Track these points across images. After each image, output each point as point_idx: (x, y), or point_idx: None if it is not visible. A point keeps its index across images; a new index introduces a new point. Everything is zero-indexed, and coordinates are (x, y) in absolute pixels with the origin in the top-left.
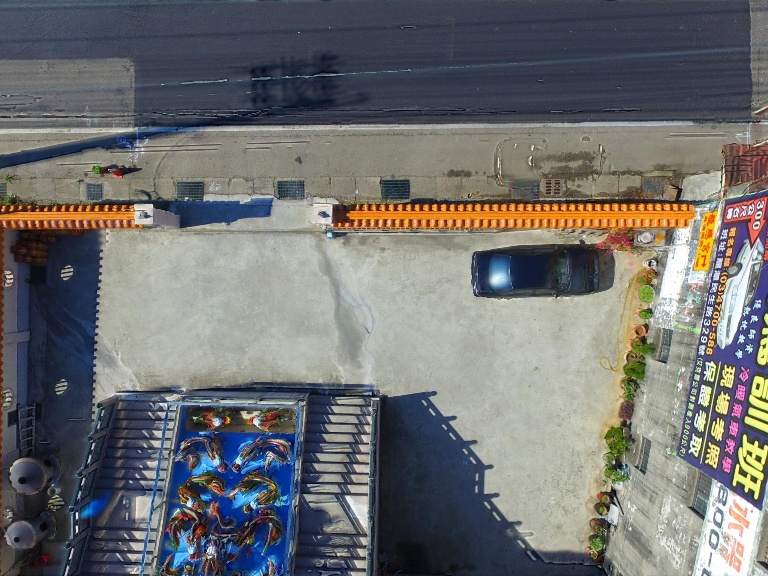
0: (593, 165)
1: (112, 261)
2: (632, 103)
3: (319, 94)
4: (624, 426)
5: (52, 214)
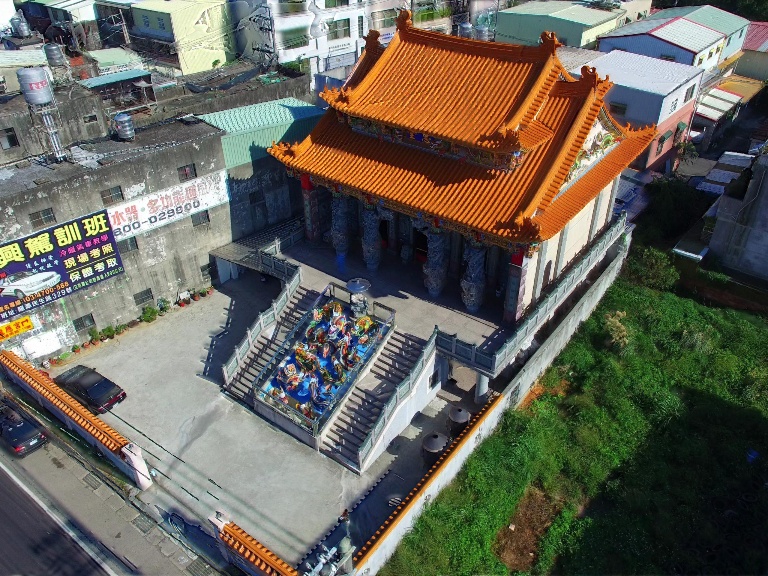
0: (3, 422)
1: (293, 557)
2: None
3: (57, 567)
4: (142, 320)
5: (278, 568)
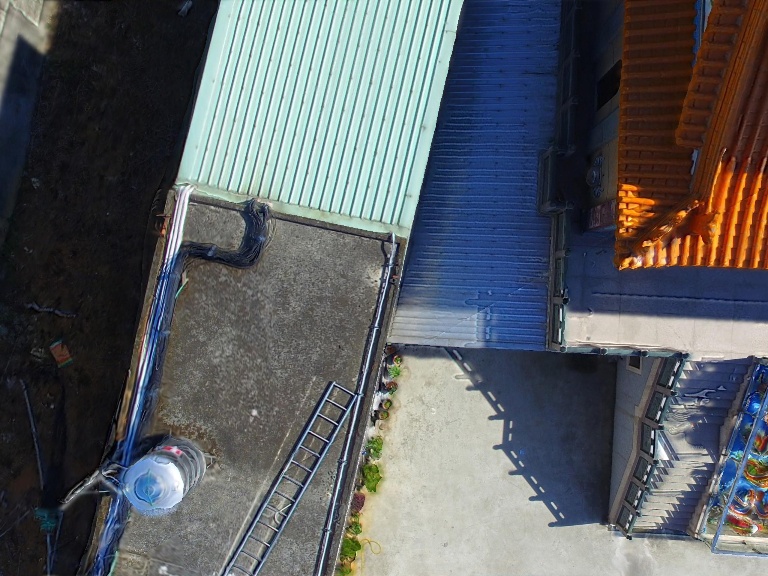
0: None
1: None
2: None
3: None
4: None
5: None
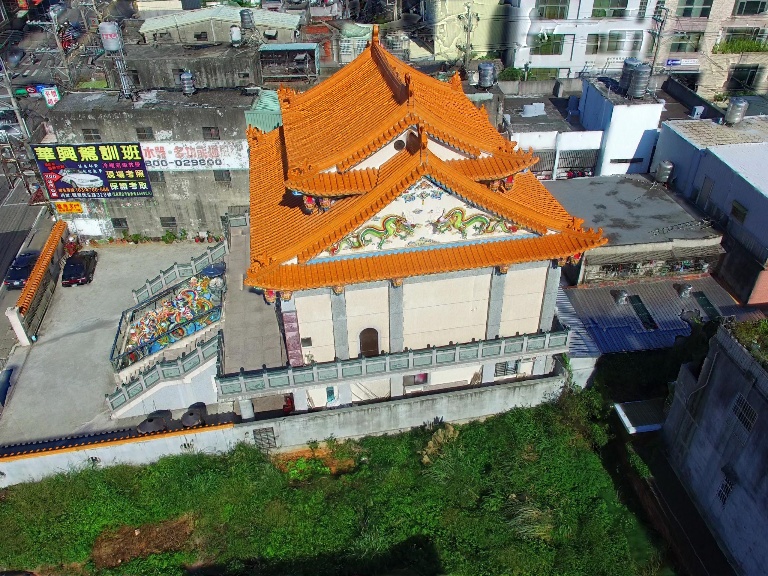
0: (33, 265)
1: (14, 439)
2: (6, 258)
3: None
4: None
5: None
